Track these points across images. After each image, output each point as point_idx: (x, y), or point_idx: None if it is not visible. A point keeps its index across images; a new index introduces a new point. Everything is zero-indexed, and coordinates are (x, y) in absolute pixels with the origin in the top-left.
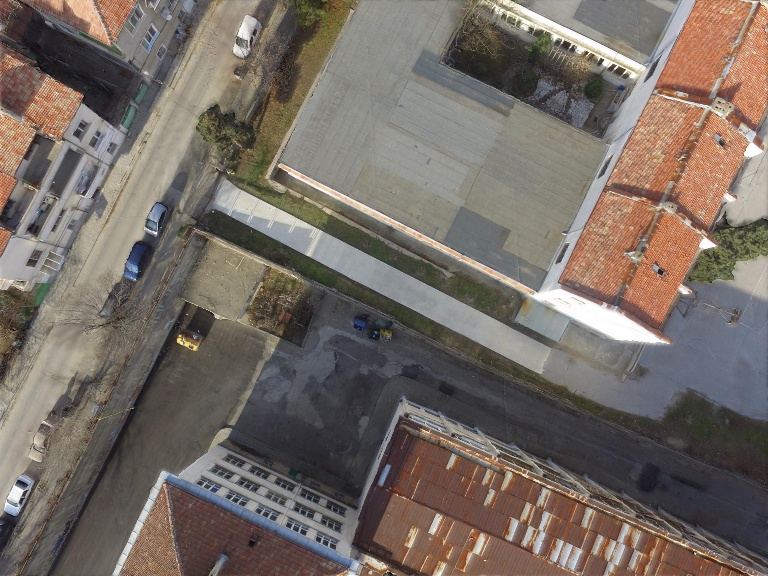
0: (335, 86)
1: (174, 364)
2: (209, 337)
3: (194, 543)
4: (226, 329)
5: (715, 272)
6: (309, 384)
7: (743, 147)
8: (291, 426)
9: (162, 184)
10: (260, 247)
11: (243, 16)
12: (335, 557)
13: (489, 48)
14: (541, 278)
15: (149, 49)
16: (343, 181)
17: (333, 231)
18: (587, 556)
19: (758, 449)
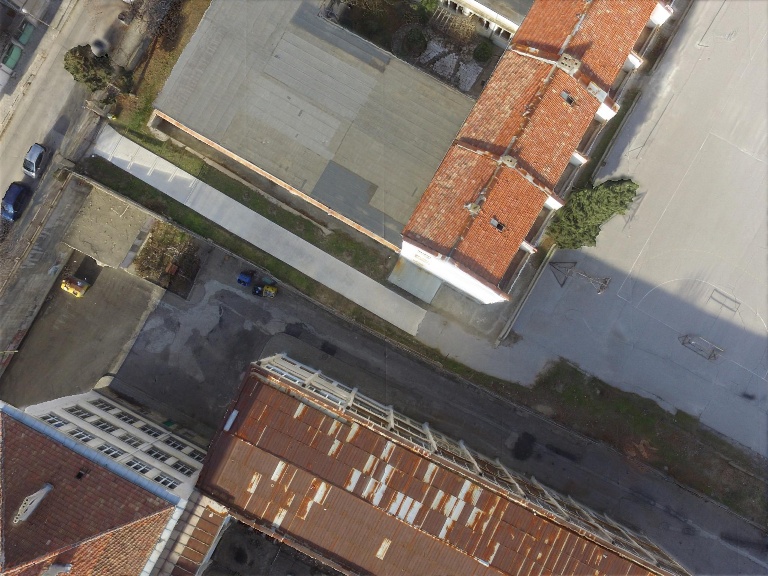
0: (212, 33)
1: (60, 310)
2: (96, 285)
3: (21, 471)
4: (113, 278)
5: (578, 238)
6: (192, 337)
7: (594, 107)
8: (172, 377)
9: (44, 126)
10: (138, 194)
11: None
12: (164, 494)
13: (368, 2)
14: None
15: None
16: (214, 129)
17: (213, 182)
18: (427, 510)
19: (627, 422)
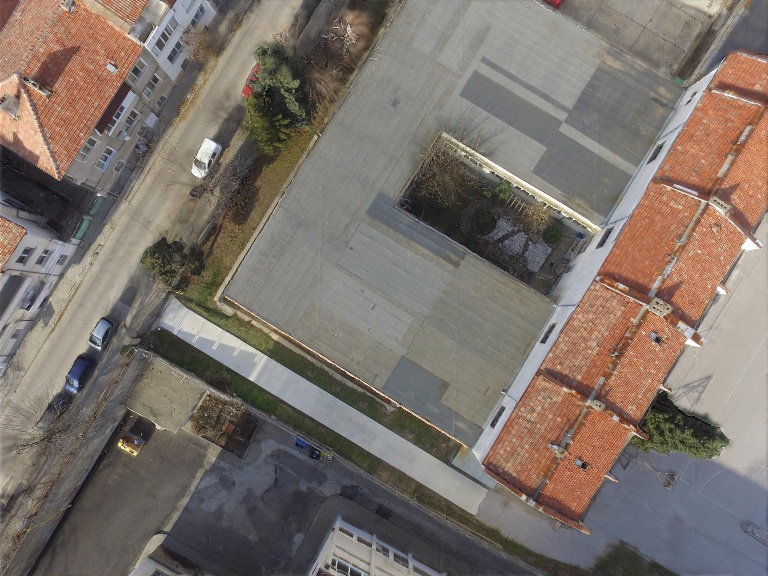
0: (286, 222)
1: (115, 465)
2: (151, 441)
3: None
4: (169, 434)
5: None
6: (247, 496)
7: (681, 343)
8: (226, 537)
9: (111, 297)
10: (203, 369)
11: (205, 134)
12: None
13: (444, 197)
14: (476, 435)
15: (105, 167)
16: (286, 320)
17: (278, 357)
18: None
19: None
